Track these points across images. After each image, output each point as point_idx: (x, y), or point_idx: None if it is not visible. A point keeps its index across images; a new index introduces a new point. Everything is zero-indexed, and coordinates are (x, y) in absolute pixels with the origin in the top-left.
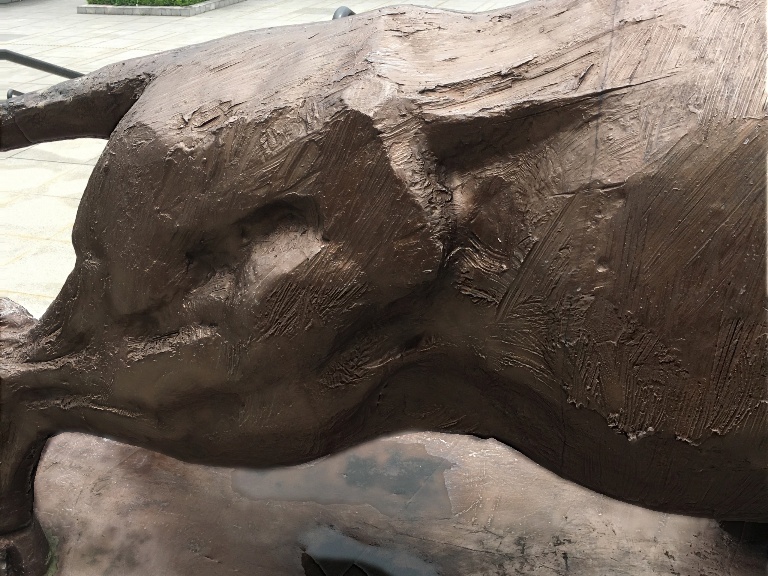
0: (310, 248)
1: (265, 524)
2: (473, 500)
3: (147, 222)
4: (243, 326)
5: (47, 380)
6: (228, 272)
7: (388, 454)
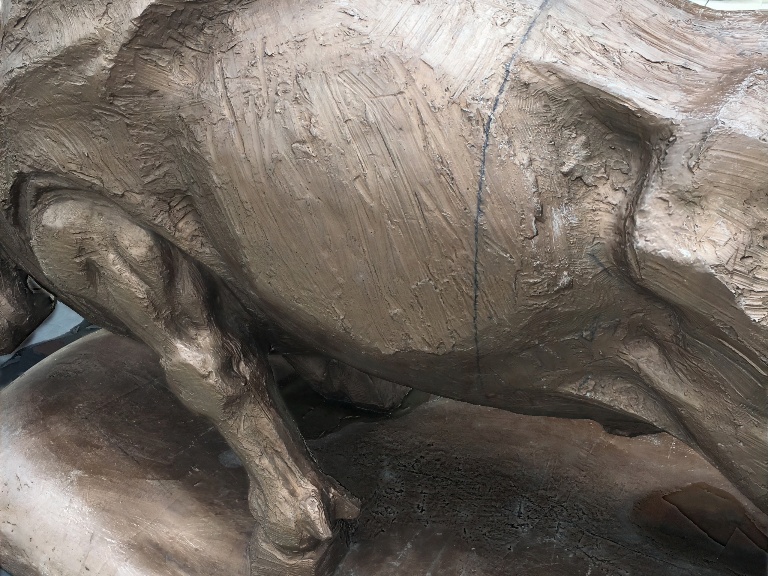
0: None
1: None
2: None
3: None
4: None
5: None
6: None
7: None
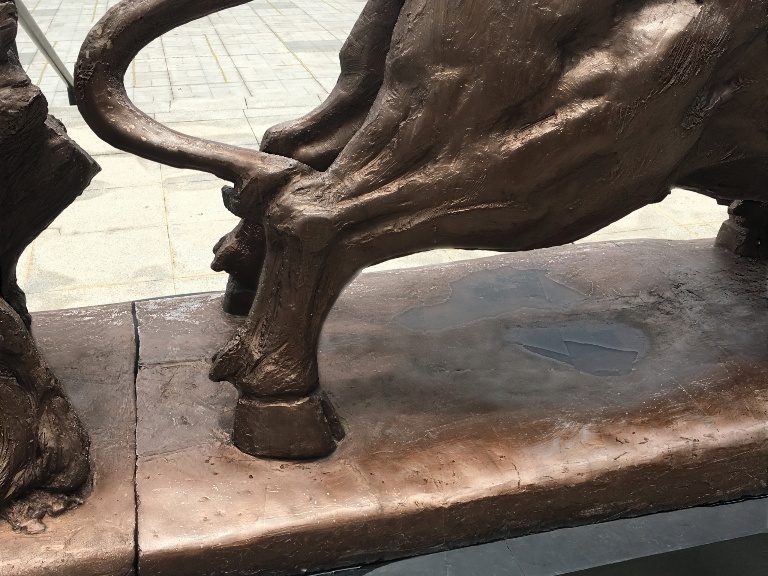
0: (691, 10)
1: (470, 340)
2: (589, 284)
3: (526, 18)
4: (647, 83)
5: (379, 208)
6: (599, 51)
7: (493, 277)
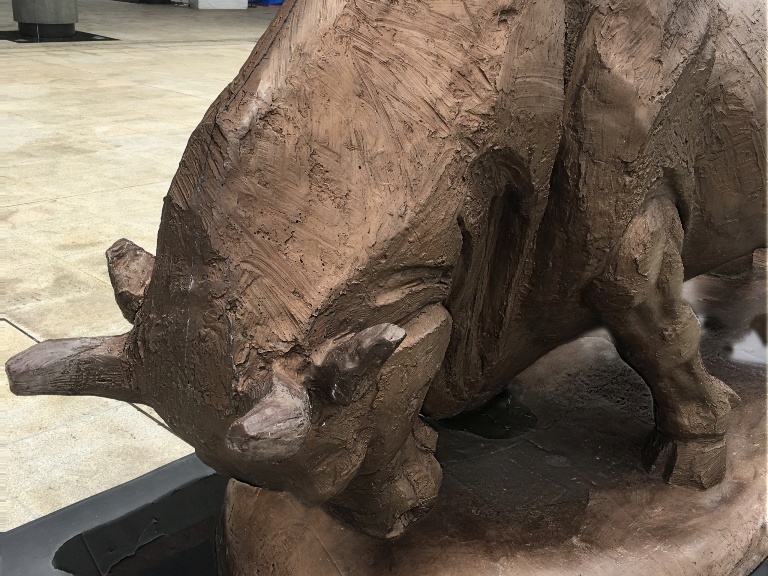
0: None
1: (730, 314)
2: None
3: None
4: None
5: None
6: None
7: None
